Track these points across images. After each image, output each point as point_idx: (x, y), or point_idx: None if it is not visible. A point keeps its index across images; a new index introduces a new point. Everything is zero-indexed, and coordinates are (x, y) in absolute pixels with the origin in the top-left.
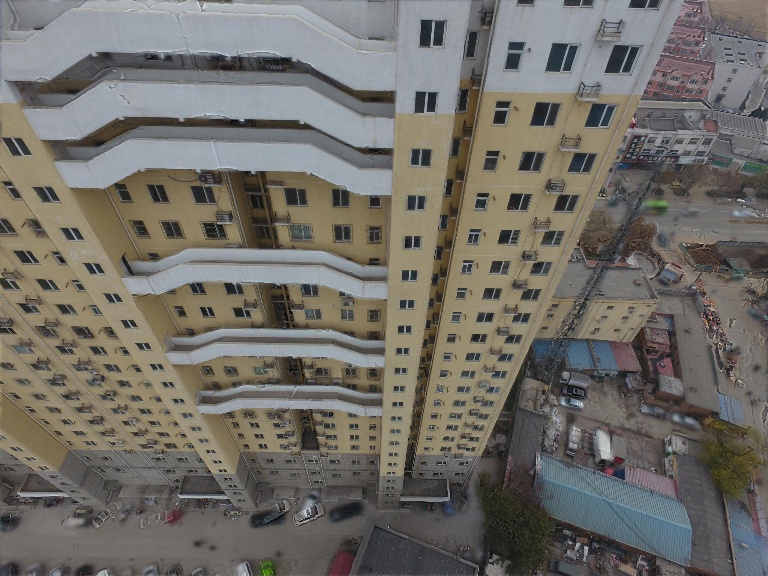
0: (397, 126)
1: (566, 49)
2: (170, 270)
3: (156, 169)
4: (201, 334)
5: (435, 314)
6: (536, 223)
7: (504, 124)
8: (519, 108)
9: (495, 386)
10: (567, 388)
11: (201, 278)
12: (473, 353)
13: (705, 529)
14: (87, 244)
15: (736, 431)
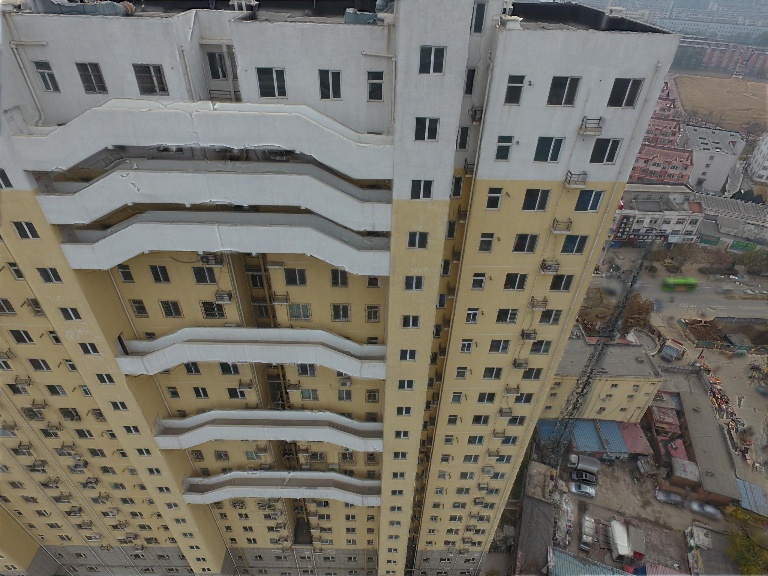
0: (394, 211)
1: (552, 142)
2: (165, 350)
3: (159, 251)
4: (193, 416)
5: (435, 394)
6: (533, 302)
7: (497, 208)
8: (511, 194)
9: (500, 472)
10: (576, 473)
11: (196, 358)
12: (475, 436)
13: None
14: (84, 324)
15: (761, 521)
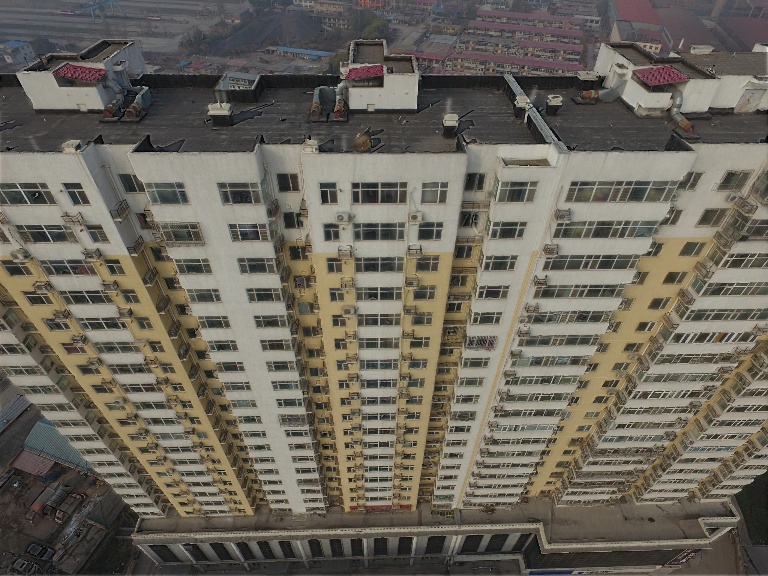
0: None
1: None
2: None
3: None
4: None
5: None
6: None
7: None
8: None
9: None
10: (30, 572)
11: None
12: None
13: (26, 425)
14: None
15: None
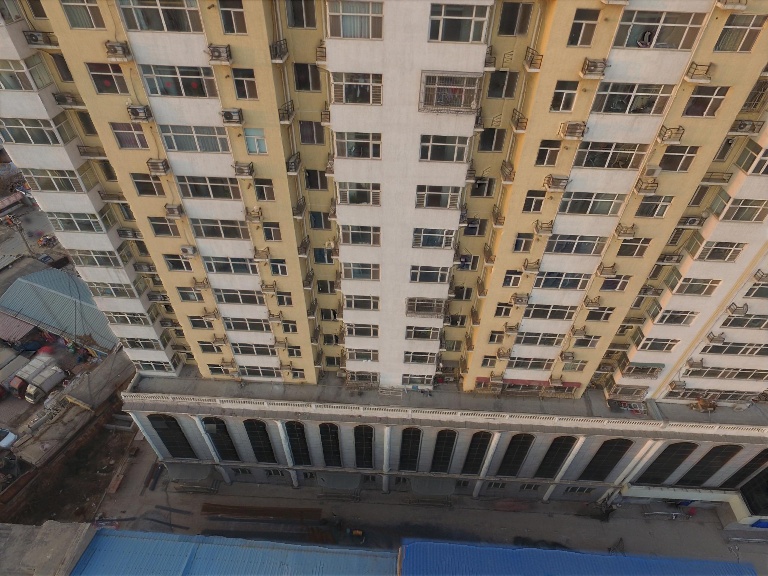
0: None
1: None
2: None
3: None
4: None
5: None
6: None
7: None
8: None
9: None
10: None
11: None
12: None
13: (3, 283)
14: None
15: None
